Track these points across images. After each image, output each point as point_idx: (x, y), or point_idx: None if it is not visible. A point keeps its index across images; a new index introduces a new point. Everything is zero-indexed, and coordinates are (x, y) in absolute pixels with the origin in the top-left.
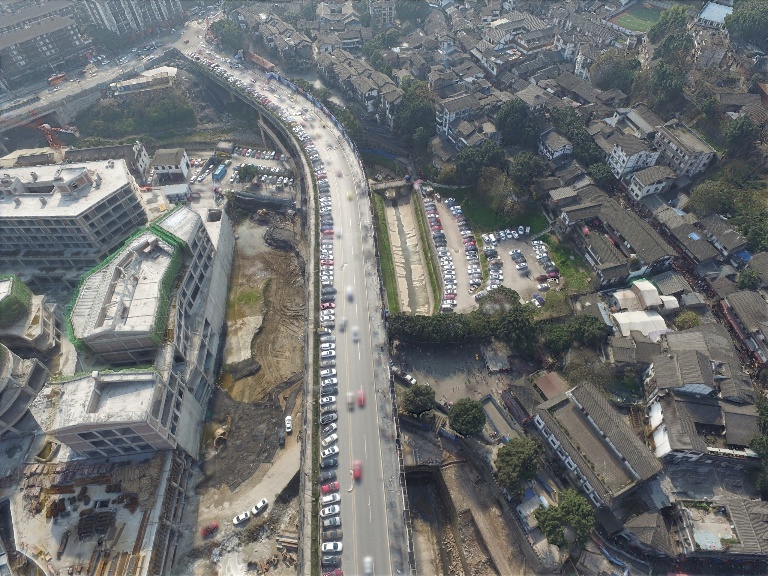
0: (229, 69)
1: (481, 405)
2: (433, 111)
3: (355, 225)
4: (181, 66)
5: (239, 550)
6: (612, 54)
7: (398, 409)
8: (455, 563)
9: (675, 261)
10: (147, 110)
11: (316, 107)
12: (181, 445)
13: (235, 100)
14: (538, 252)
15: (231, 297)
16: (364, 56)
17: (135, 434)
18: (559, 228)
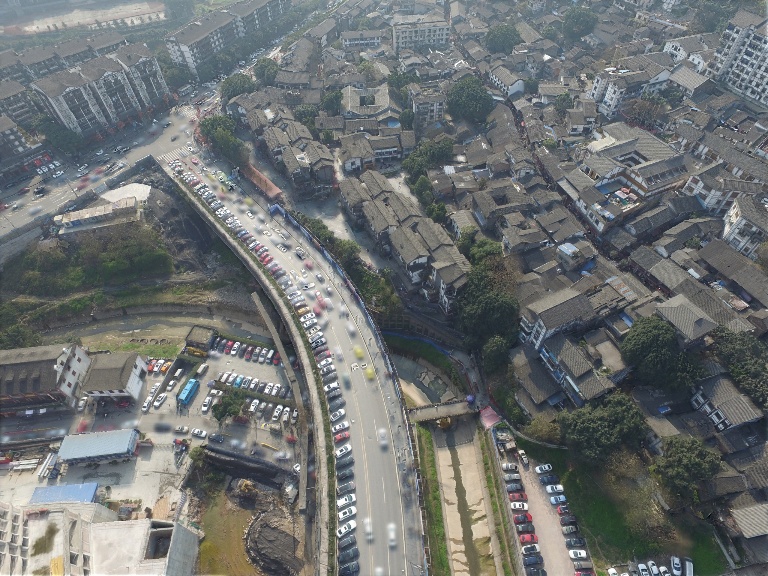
0: (220, 192)
1: None
2: (516, 309)
3: (397, 575)
4: (156, 183)
5: None
6: None
7: None
8: None
9: None
10: (102, 257)
11: (336, 274)
12: None
13: None
14: None
15: None
16: (404, 171)
17: None
18: None
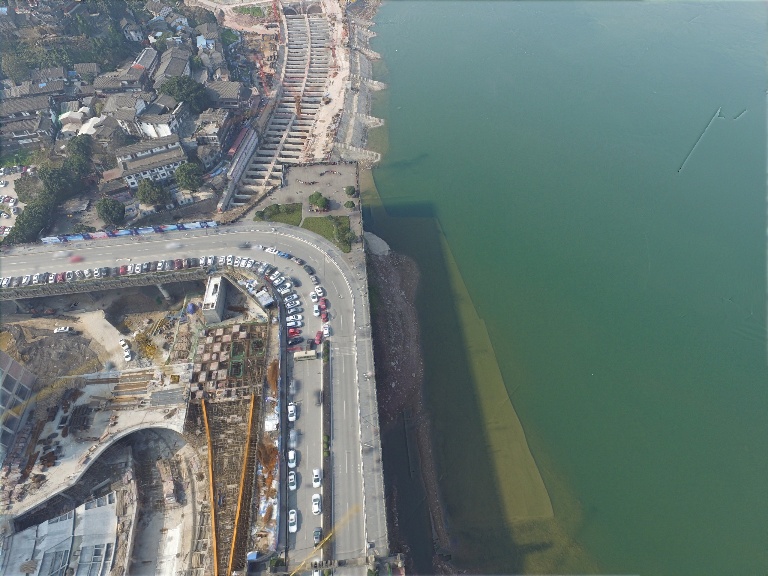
0: None
1: None
2: None
3: None
4: None
5: (152, 358)
6: None
7: None
8: None
9: None
10: None
11: None
12: None
13: None
14: None
15: None
16: None
17: (3, 374)
18: None
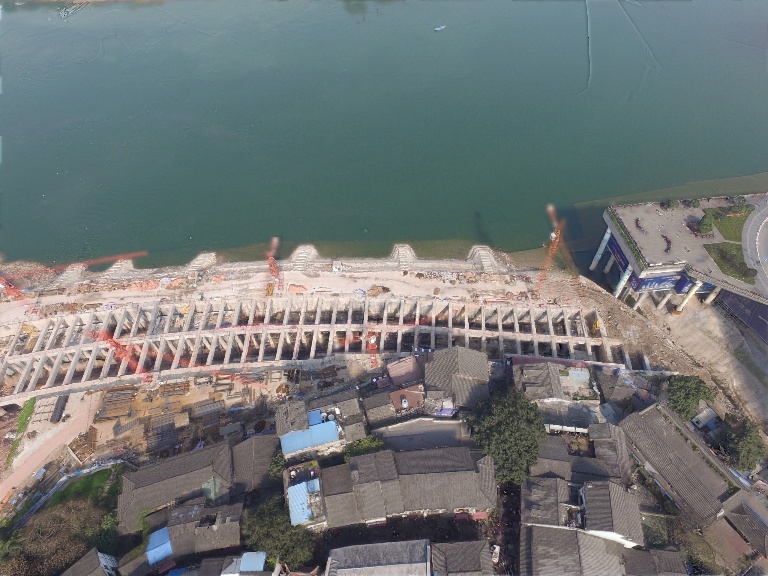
0: None
1: None
2: None
3: None
4: None
5: None
6: None
7: None
8: None
9: None
10: None
11: None
12: None
13: None
14: None
15: None
16: None
17: None
18: None
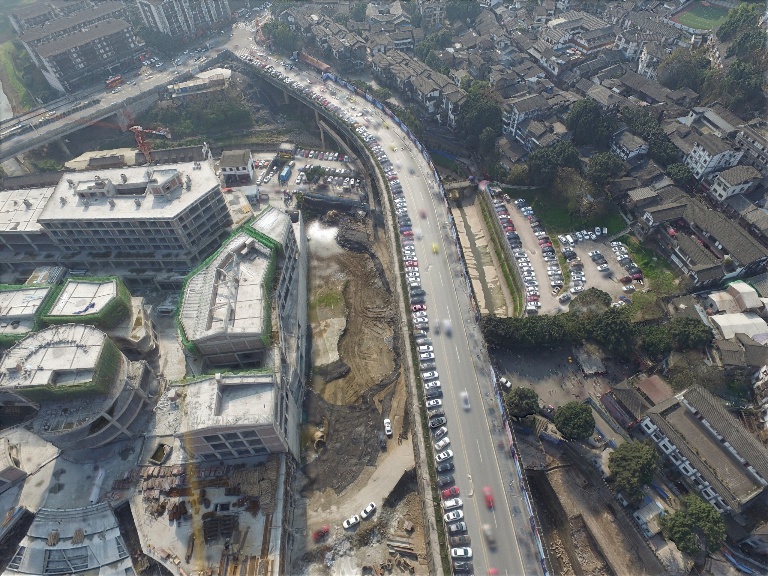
0: (283, 70)
1: (590, 409)
2: (499, 111)
3: (434, 226)
4: (235, 68)
5: (351, 554)
6: (682, 53)
7: None
8: (566, 569)
9: (767, 262)
10: (205, 112)
11: (376, 108)
12: (290, 448)
13: (289, 101)
14: (618, 253)
15: (311, 299)
16: (416, 57)
17: (257, 437)
18: (641, 229)
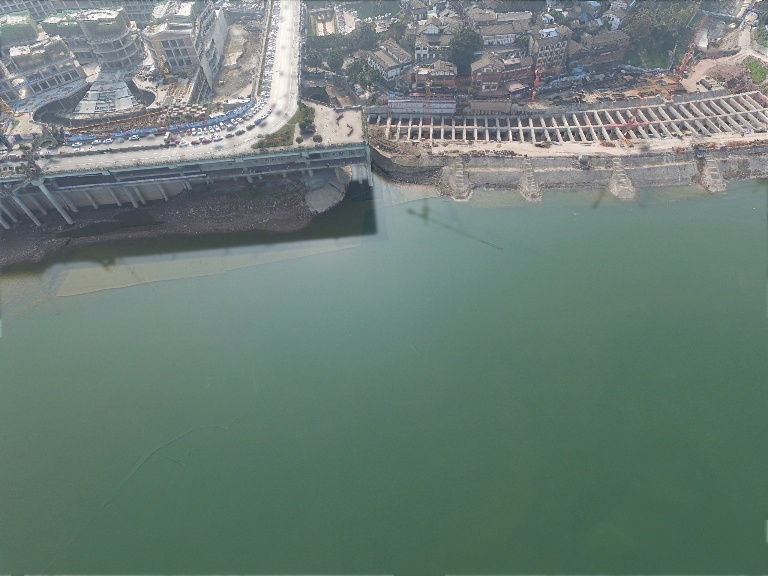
0: None
1: None
2: None
3: (292, 10)
4: None
5: None
6: None
7: (307, 70)
8: None
9: None
10: None
11: None
12: None
13: None
14: None
15: (226, 47)
16: None
17: (185, 47)
18: (403, 7)
